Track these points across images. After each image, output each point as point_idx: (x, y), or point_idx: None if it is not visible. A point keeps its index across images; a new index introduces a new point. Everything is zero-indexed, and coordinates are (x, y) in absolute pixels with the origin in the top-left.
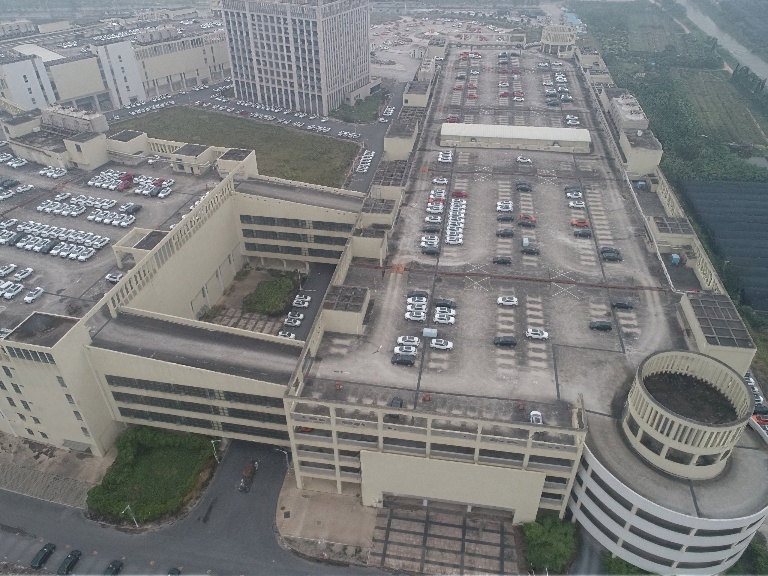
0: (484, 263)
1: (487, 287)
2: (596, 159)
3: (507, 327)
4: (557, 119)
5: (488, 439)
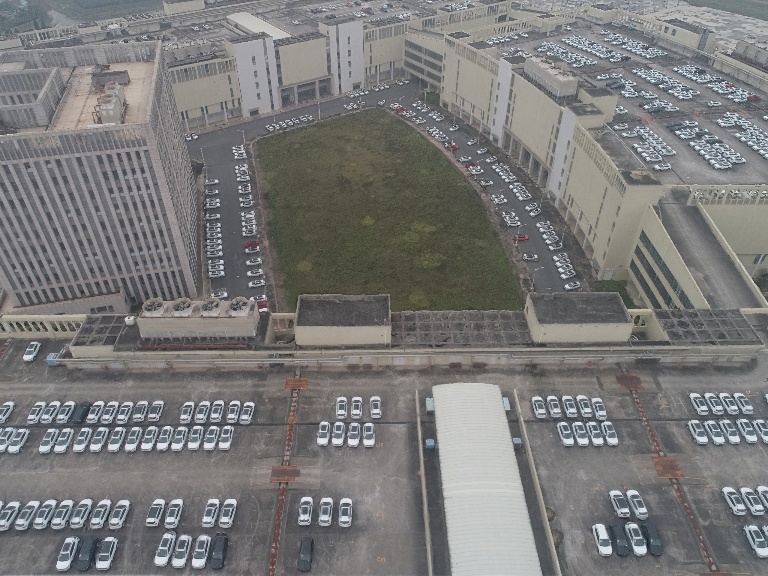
0: None
1: (426, 6)
2: (263, 15)
3: (441, 0)
4: (200, 33)
5: None
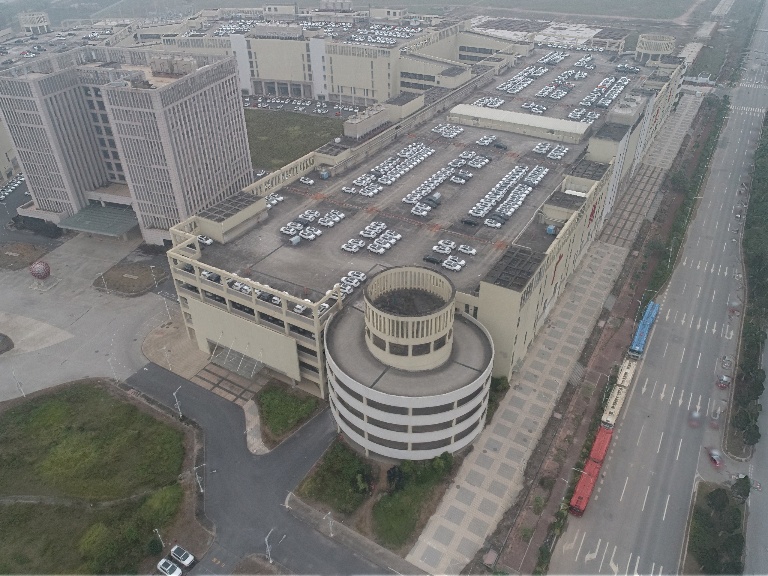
0: (61, 45)
1: None
2: None
3: None
4: None
5: (91, 26)
